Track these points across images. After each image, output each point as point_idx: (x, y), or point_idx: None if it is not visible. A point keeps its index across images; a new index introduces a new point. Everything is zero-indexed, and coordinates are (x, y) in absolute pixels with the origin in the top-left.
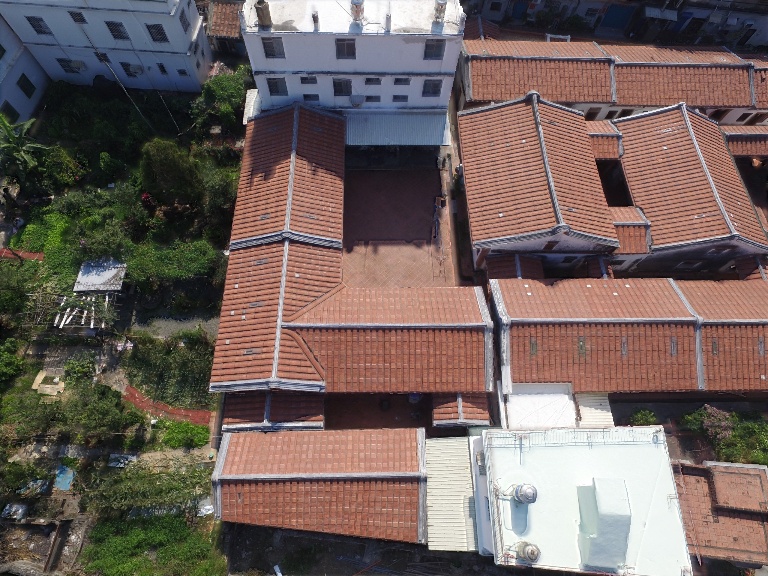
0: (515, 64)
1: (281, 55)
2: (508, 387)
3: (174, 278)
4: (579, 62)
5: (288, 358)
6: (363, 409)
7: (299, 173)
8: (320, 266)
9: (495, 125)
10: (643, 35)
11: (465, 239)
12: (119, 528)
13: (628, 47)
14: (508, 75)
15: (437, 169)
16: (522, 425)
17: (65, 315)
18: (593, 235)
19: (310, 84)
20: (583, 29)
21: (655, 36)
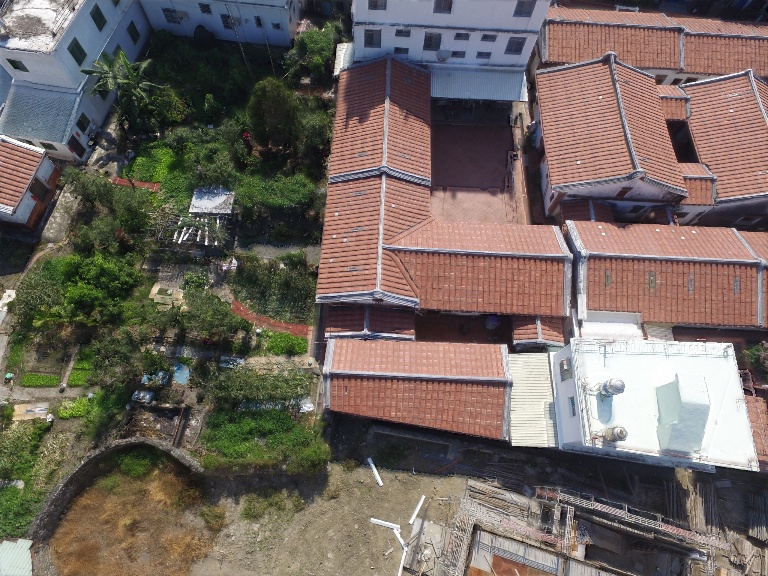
0: (589, 29)
1: (382, 7)
2: (583, 313)
3: (278, 206)
4: (650, 30)
5: (388, 275)
6: (444, 332)
7: (392, 117)
8: (412, 200)
9: (572, 83)
10: (706, 11)
11: (536, 189)
12: (232, 417)
13: (695, 20)
14: (582, 39)
15: (509, 126)
16: None
17: (182, 232)
18: (665, 183)
19: (403, 37)
20: (648, 4)
21: (718, 12)
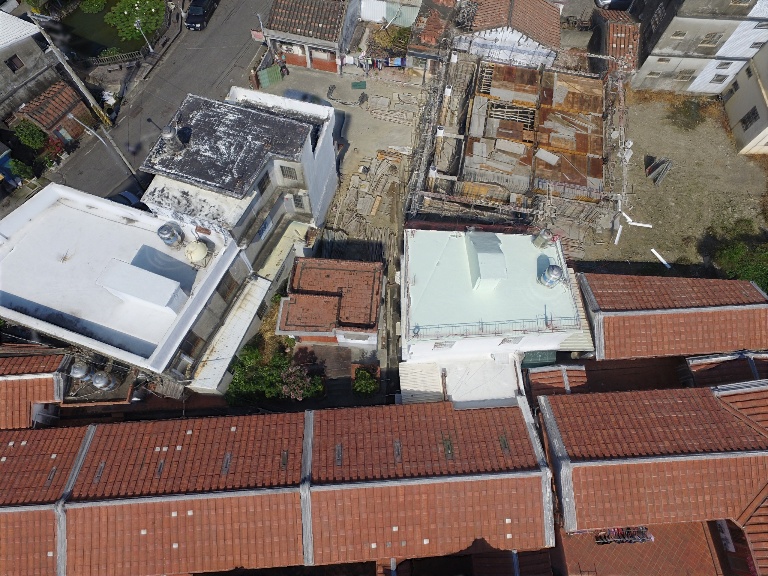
0: None
1: None
2: (523, 401)
3: None
4: None
5: None
6: None
7: None
8: None
9: None
10: None
11: None
12: None
13: None
14: None
15: None
16: (508, 363)
17: None
18: None
19: None
20: None
21: None
